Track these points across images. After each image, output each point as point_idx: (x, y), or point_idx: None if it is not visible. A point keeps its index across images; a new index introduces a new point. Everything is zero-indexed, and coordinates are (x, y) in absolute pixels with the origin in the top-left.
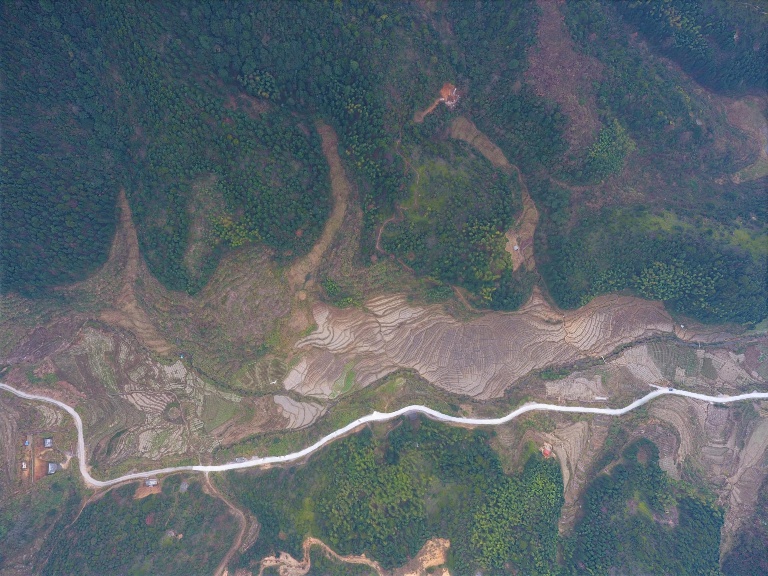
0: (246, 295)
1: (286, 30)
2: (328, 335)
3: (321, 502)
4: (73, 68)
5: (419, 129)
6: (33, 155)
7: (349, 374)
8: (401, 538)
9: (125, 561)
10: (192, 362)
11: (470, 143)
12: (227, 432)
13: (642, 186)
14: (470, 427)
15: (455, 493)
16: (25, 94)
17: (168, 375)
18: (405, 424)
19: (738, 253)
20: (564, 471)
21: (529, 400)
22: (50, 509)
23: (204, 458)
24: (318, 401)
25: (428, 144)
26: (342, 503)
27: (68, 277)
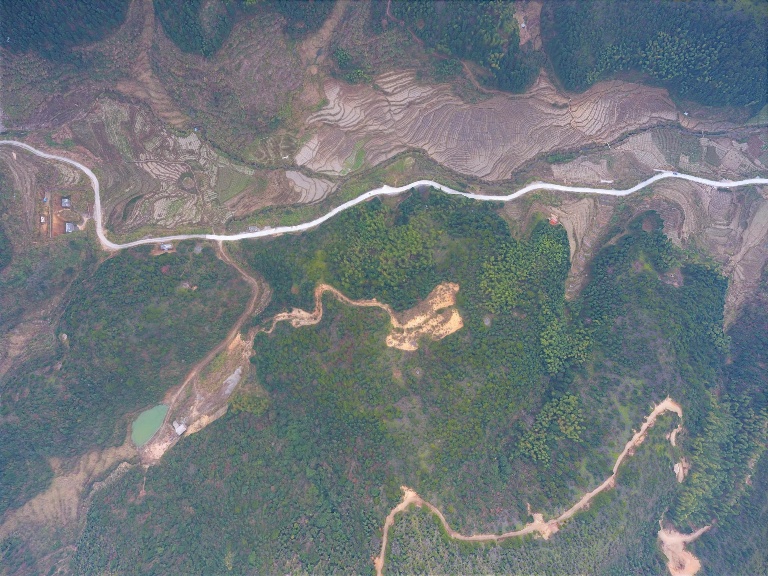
0: (259, 64)
1: None
2: (339, 111)
3: (333, 251)
4: None
5: None
6: None
7: (359, 152)
8: (411, 285)
9: (142, 299)
10: (206, 135)
11: None
12: (240, 204)
13: None
14: None
15: (464, 246)
16: None
17: (182, 147)
18: (414, 192)
19: (741, 18)
20: (570, 242)
21: (536, 179)
22: (67, 266)
23: (217, 229)
24: (329, 178)
25: None
26: (353, 257)
27: (86, 33)
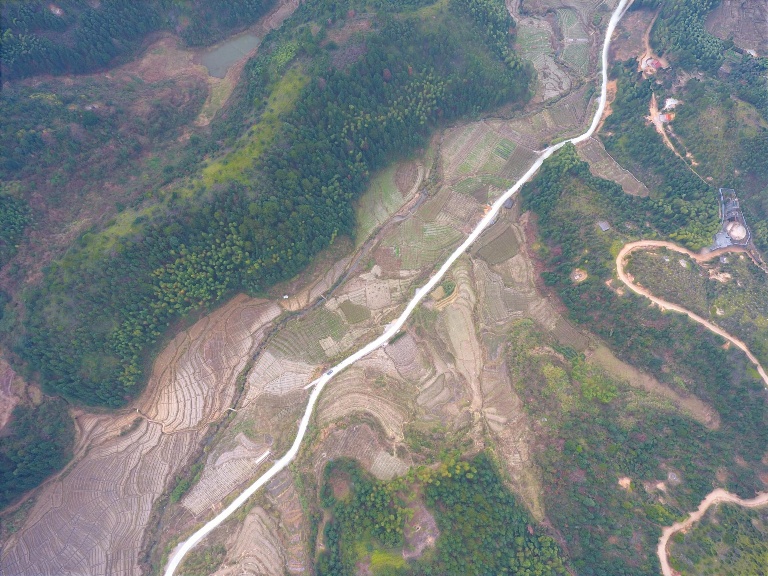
0: None
1: None
2: None
3: None
4: None
5: None
6: None
7: None
8: None
9: None
10: None
11: None
12: None
13: (88, 210)
14: None
15: None
16: None
17: None
18: None
19: (221, 190)
20: None
21: (170, 549)
22: None
23: None
24: None
25: None
26: None
27: None
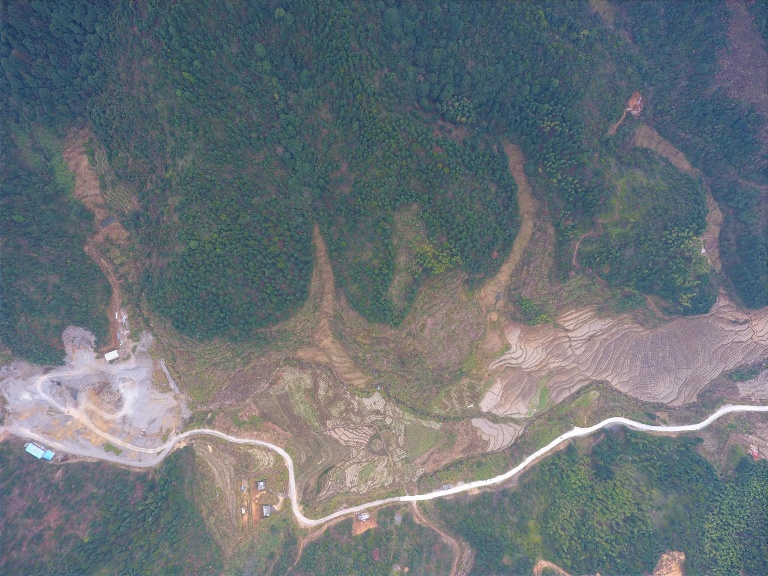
0: (443, 321)
1: (490, 54)
2: (521, 354)
3: (548, 524)
4: (278, 110)
5: (613, 141)
6: (247, 200)
7: (543, 391)
8: (633, 554)
9: None
10: (389, 392)
11: (654, 150)
12: (430, 460)
13: None
14: (672, 435)
15: (679, 504)
16: (240, 140)
17: (367, 407)
18: (611, 437)
19: None
20: None
21: (725, 403)
22: (269, 552)
23: (409, 488)
24: (515, 421)
25: (624, 155)
26: (565, 523)
27: (274, 318)
